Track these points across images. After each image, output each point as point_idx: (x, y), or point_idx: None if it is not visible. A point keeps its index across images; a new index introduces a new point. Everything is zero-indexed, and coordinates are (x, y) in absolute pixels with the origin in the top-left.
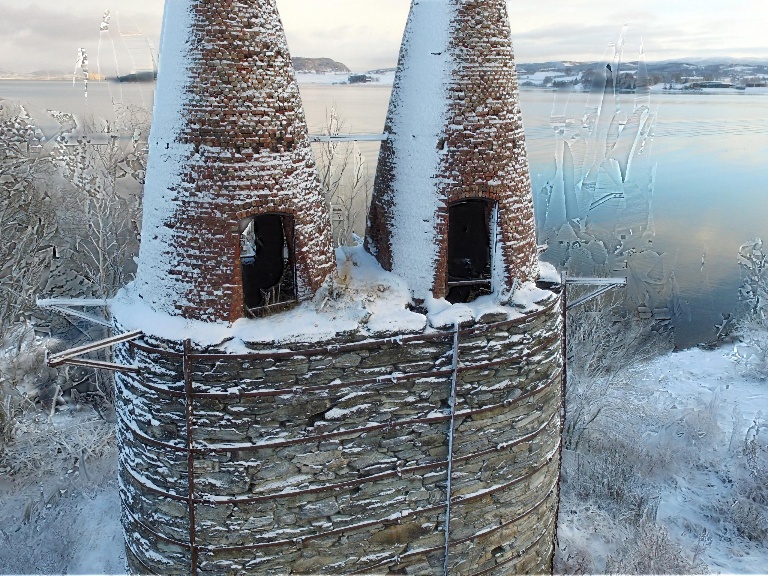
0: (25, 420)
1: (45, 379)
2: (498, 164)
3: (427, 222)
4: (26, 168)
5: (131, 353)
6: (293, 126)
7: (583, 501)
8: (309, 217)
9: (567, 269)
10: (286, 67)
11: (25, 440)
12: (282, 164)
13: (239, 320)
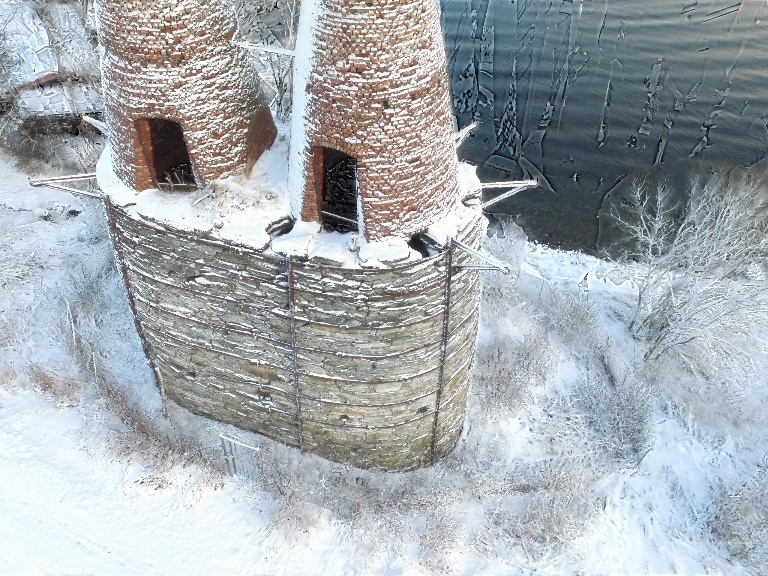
0: None
1: None
2: (358, 123)
3: (300, 155)
4: None
5: None
6: (184, 43)
7: (586, 410)
8: (201, 125)
9: (747, 172)
10: None
11: None
12: (169, 79)
13: (147, 191)
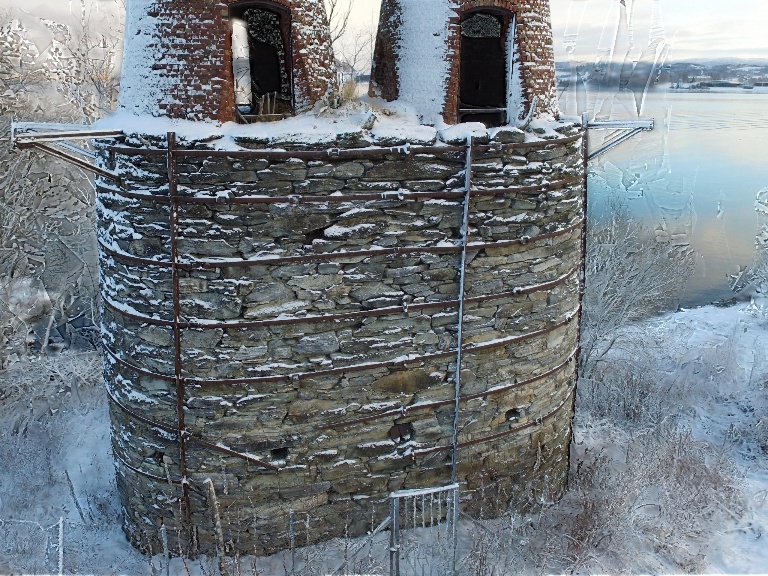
0: (15, 338)
1: (39, 311)
2: None
3: (437, 36)
4: (18, 80)
5: (111, 162)
6: None
7: None
8: (308, 18)
9: None
10: None
11: (17, 368)
12: None
13: (230, 122)
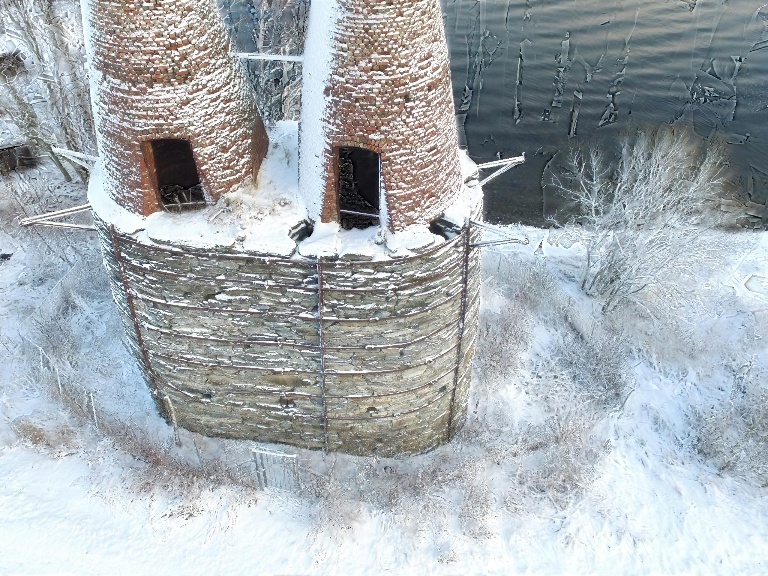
0: None
1: None
2: (382, 119)
3: (317, 158)
4: None
5: None
6: (189, 59)
7: (567, 366)
8: (209, 140)
9: (671, 129)
10: (181, 0)
11: None
12: (176, 97)
13: (153, 214)
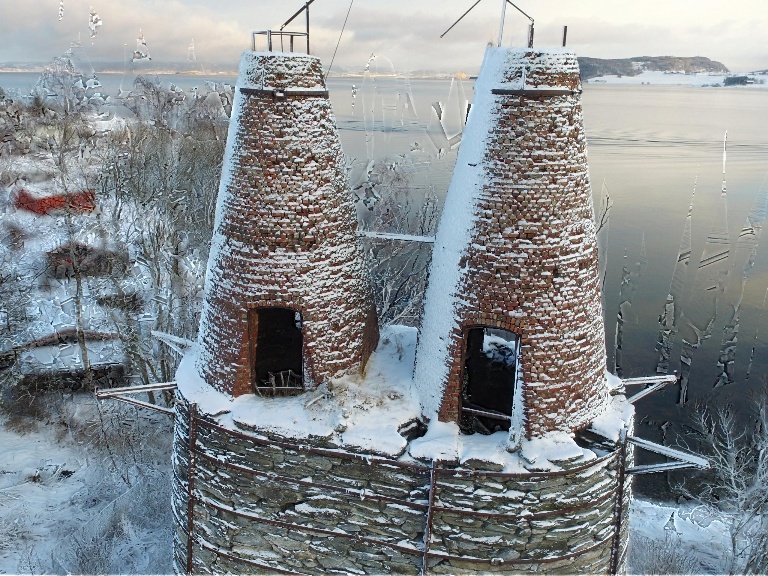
0: None
1: None
2: (525, 294)
3: (442, 340)
4: None
5: None
6: (317, 227)
7: None
8: (322, 314)
9: None
10: (320, 171)
11: None
12: (297, 263)
13: (243, 396)
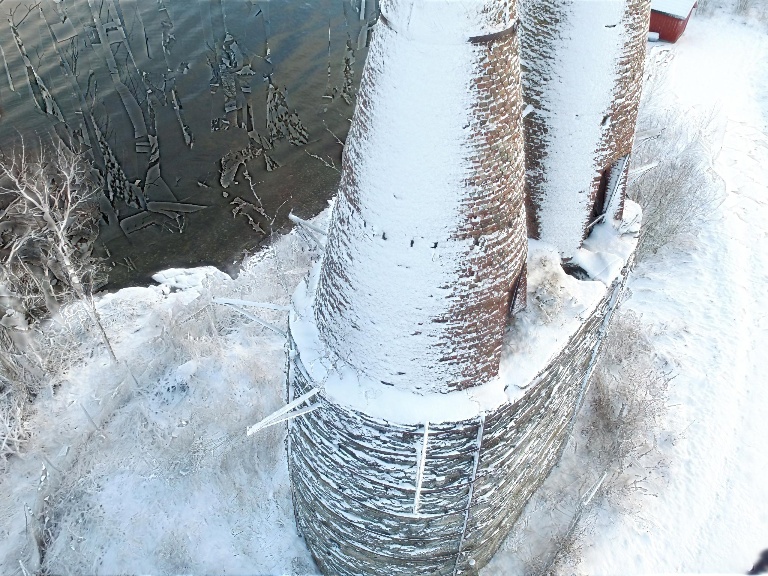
0: None
1: None
2: None
3: (583, 193)
4: None
5: (405, 439)
6: None
7: None
8: None
9: None
10: None
11: None
12: None
13: None
